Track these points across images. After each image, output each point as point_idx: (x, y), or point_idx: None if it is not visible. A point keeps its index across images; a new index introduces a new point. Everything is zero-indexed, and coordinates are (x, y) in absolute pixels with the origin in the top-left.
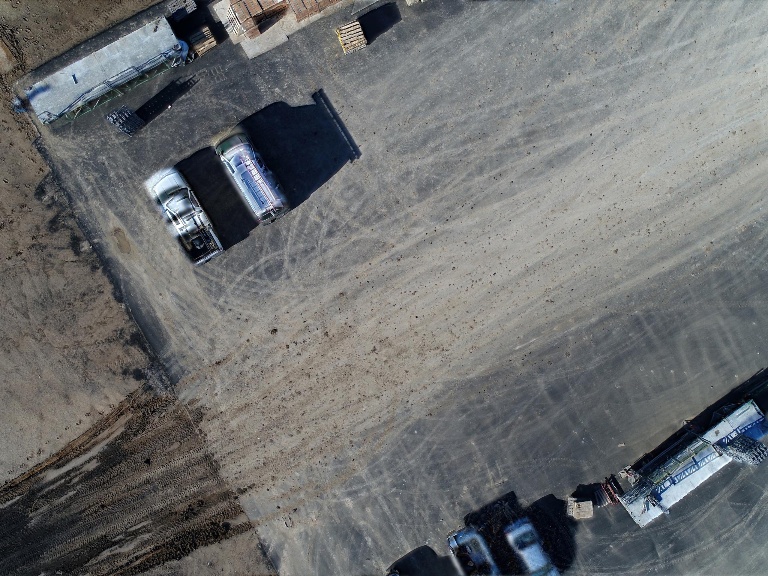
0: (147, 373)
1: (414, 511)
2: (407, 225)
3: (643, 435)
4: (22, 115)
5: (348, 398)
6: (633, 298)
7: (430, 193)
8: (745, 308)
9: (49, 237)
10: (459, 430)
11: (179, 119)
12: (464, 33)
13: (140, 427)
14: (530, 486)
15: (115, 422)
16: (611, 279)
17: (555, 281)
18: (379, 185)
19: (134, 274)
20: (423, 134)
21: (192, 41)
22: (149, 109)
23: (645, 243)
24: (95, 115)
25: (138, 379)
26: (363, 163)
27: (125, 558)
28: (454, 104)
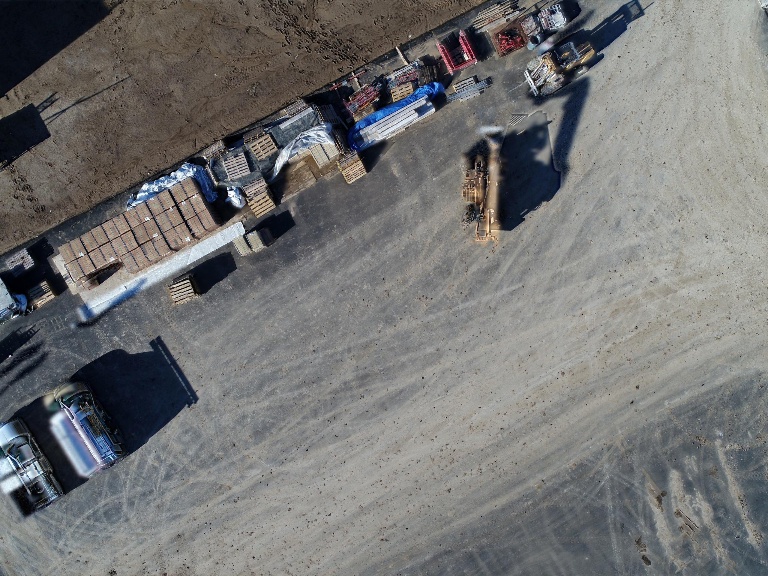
0: None
1: None
2: (244, 467)
3: None
4: None
5: None
6: (467, 536)
7: (266, 436)
8: (578, 544)
9: None
10: None
11: (19, 368)
12: (298, 281)
13: None
14: None
15: None
16: (445, 518)
17: (390, 520)
18: (216, 429)
19: None
20: (259, 379)
21: (30, 295)
22: None
23: (477, 482)
24: None
25: None
26: (200, 407)
27: None
28: (289, 349)
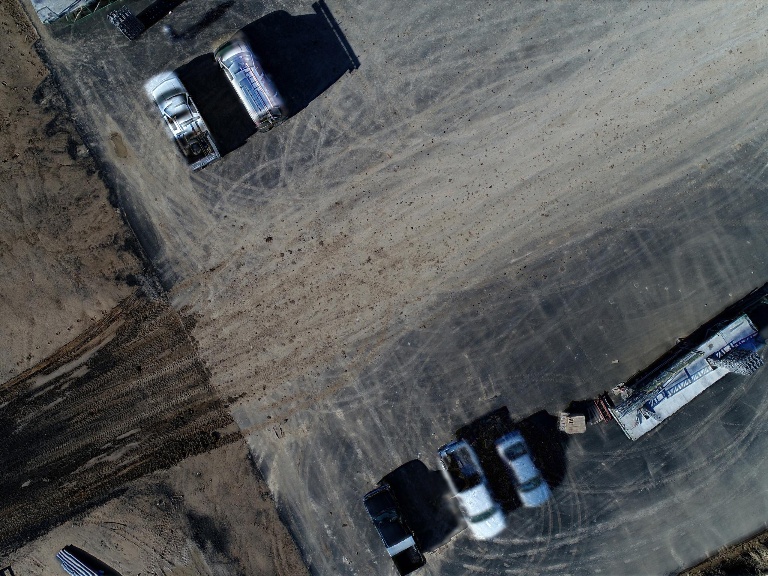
0: (140, 279)
1: (406, 424)
2: (404, 136)
3: (637, 352)
4: (22, 17)
5: (342, 308)
6: (628, 214)
7: (428, 105)
8: (740, 227)
9: (46, 140)
10: (453, 343)
11: (179, 25)
12: None
13: (132, 333)
14: (523, 401)
15: (107, 328)
16: (607, 194)
17: (551, 195)
18: (377, 95)
19: (130, 178)
20: (422, 46)
21: None
22: (149, 14)
23: (641, 159)
24: (95, 19)
25: (131, 285)
26: (362, 73)
27: (113, 467)
28: (453, 17)
